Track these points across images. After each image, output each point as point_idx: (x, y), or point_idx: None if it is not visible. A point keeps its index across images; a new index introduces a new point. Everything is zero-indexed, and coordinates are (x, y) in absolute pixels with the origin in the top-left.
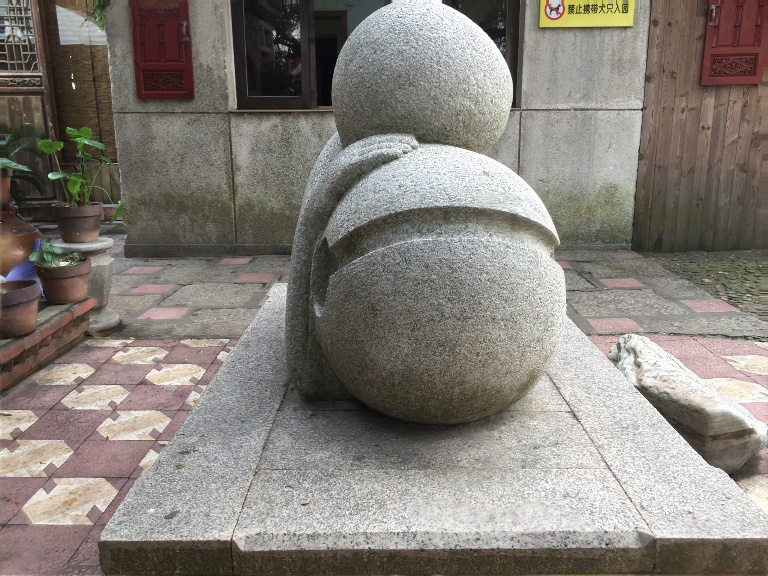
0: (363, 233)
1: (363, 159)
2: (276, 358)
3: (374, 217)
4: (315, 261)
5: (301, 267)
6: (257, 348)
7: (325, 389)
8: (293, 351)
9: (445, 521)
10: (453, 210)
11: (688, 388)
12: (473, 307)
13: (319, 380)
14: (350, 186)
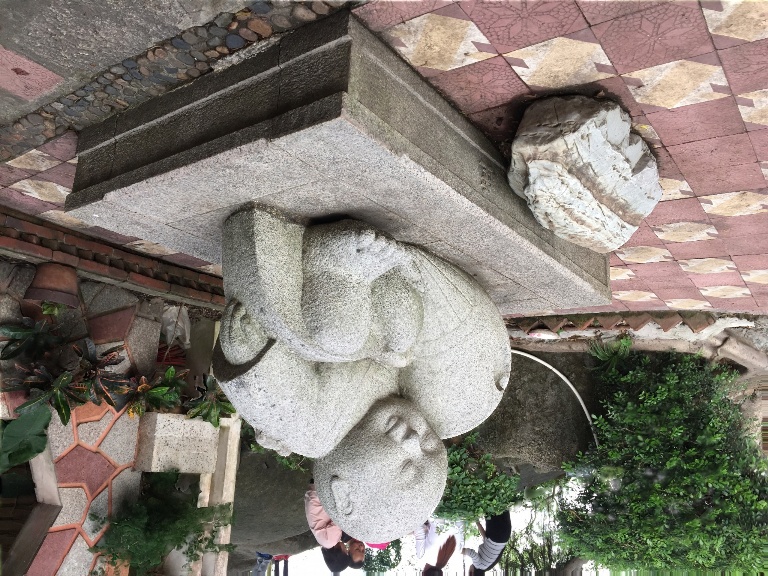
0: None
1: None
2: None
3: None
4: None
5: None
6: None
7: None
8: None
9: None
10: None
11: (590, 245)
12: None
13: None
14: None
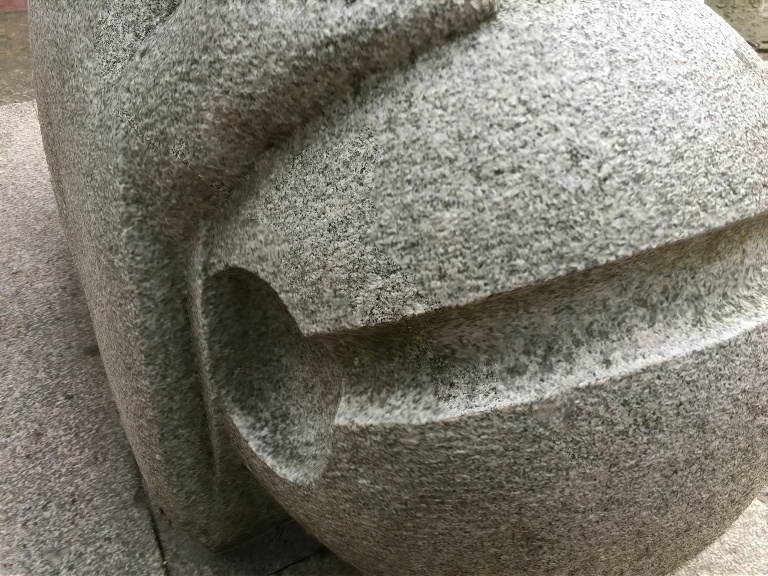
0: (454, 316)
1: (377, 23)
2: (64, 394)
3: (513, 282)
4: (209, 311)
5: (158, 319)
6: (1, 368)
7: (259, 520)
8: (181, 497)
9: None
10: (736, 223)
11: None
12: (767, 467)
13: (246, 514)
14: (319, 110)
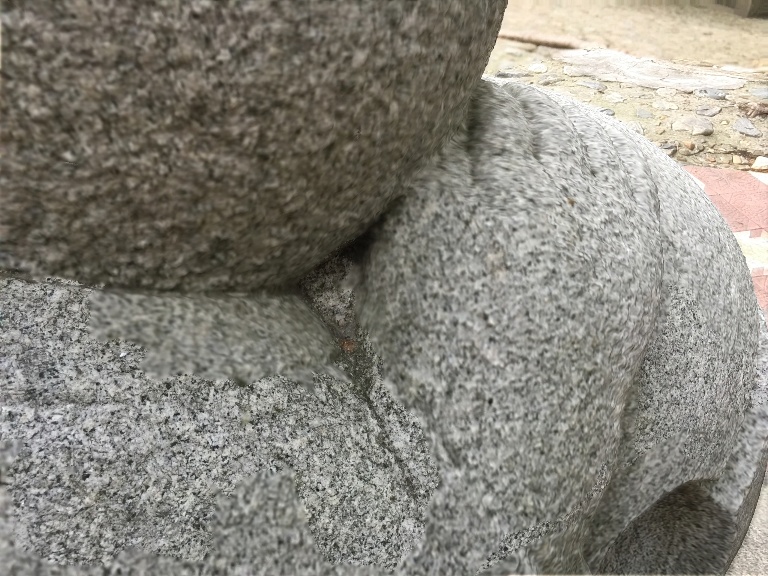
0: None
1: None
2: None
3: None
4: None
5: None
6: None
7: None
8: None
9: (767, 490)
10: None
11: None
12: None
13: None
14: None
